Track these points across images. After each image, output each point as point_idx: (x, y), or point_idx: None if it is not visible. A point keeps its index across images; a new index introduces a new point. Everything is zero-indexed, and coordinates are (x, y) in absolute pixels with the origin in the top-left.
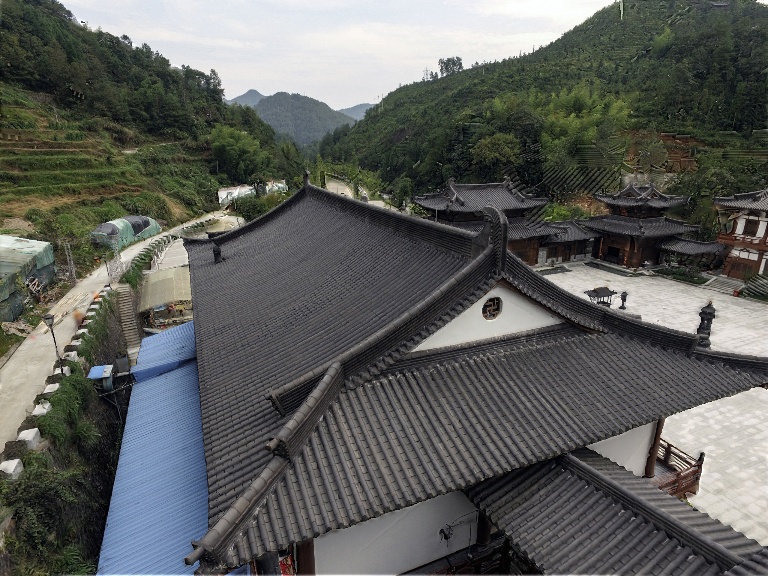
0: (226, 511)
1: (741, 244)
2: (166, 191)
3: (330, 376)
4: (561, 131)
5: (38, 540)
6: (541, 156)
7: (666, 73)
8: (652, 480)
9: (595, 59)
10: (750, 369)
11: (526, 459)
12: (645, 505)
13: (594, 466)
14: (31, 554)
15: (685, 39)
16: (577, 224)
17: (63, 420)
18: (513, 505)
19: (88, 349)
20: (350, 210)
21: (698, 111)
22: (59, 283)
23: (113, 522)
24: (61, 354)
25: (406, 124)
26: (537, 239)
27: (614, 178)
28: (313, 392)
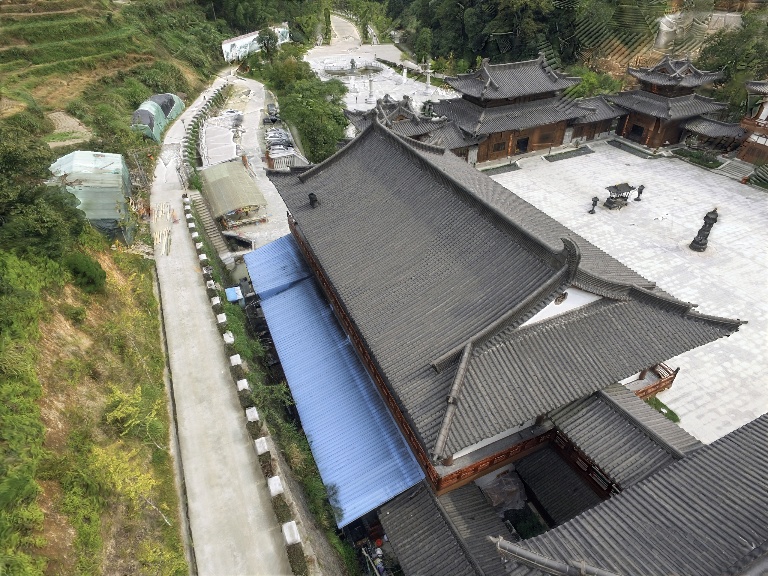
0: (437, 435)
1: (761, 130)
2: (173, 52)
3: (468, 353)
4: None
5: None
6: (576, 4)
7: None
8: (643, 381)
9: None
10: (720, 326)
11: (578, 395)
12: (641, 424)
13: (613, 392)
14: (279, 434)
15: None
16: (606, 100)
17: (246, 345)
18: (567, 416)
19: (219, 276)
20: (432, 173)
21: None
22: (139, 192)
23: (301, 408)
24: (198, 279)
25: None
26: (565, 121)
27: (651, 45)
28: (461, 365)
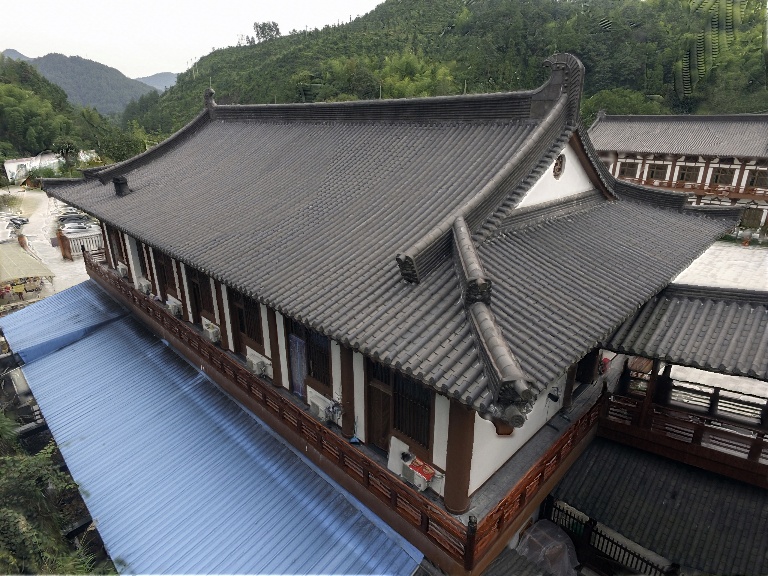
0: (489, 353)
1: None
2: None
3: (465, 228)
4: (398, 94)
5: (41, 546)
6: None
7: (475, 45)
8: None
9: (409, 32)
10: (724, 217)
11: (654, 288)
12: None
13: None
14: (31, 570)
15: (486, 16)
16: None
17: None
18: (645, 336)
19: None
20: (305, 117)
21: (503, 81)
22: None
23: (104, 515)
24: None
25: (229, 90)
26: None
27: None
28: (464, 242)
